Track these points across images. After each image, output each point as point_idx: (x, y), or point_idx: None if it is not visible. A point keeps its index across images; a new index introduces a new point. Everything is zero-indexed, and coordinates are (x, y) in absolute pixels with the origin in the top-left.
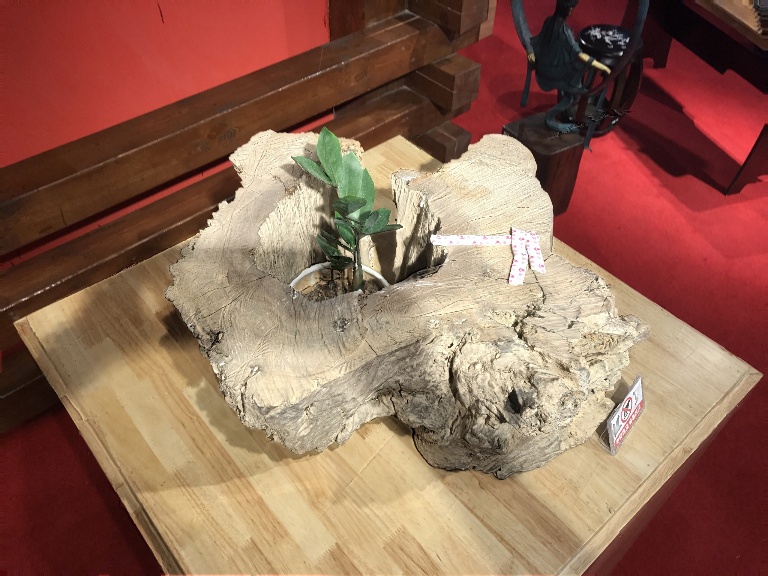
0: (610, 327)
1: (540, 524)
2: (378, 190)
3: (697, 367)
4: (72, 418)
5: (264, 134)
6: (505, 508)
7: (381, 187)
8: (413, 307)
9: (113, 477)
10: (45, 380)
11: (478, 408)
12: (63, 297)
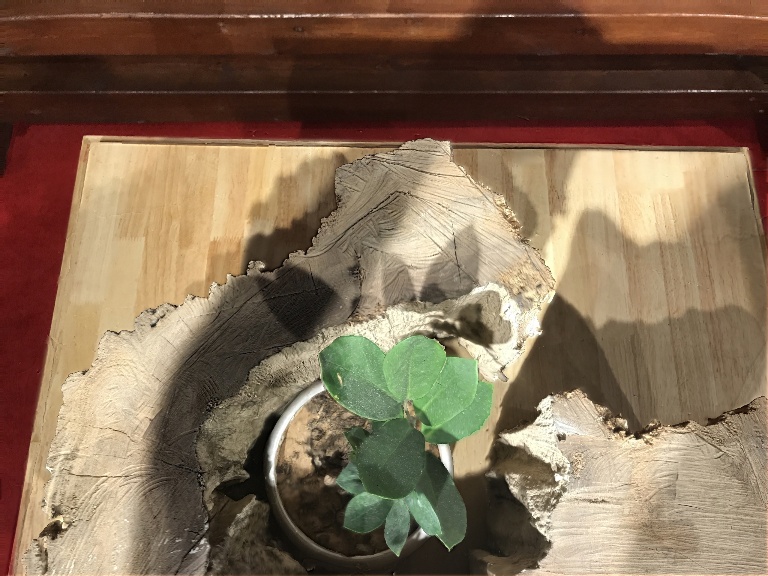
0: None
1: None
2: (624, 238)
3: None
4: None
5: (430, 146)
6: None
7: (632, 236)
8: None
9: (39, 424)
10: (63, 241)
11: None
12: (149, 135)
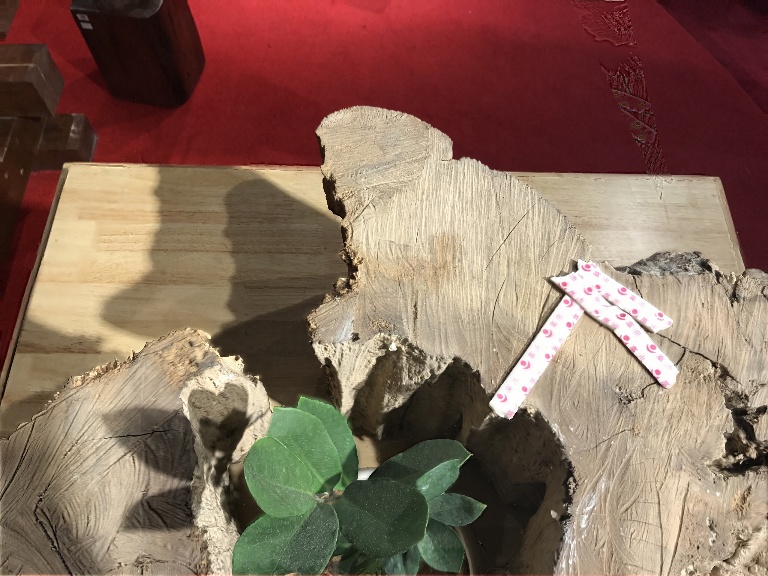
0: None
1: None
2: (141, 283)
3: (684, 223)
4: None
5: None
6: None
7: (139, 274)
8: None
9: None
10: None
11: None
12: None
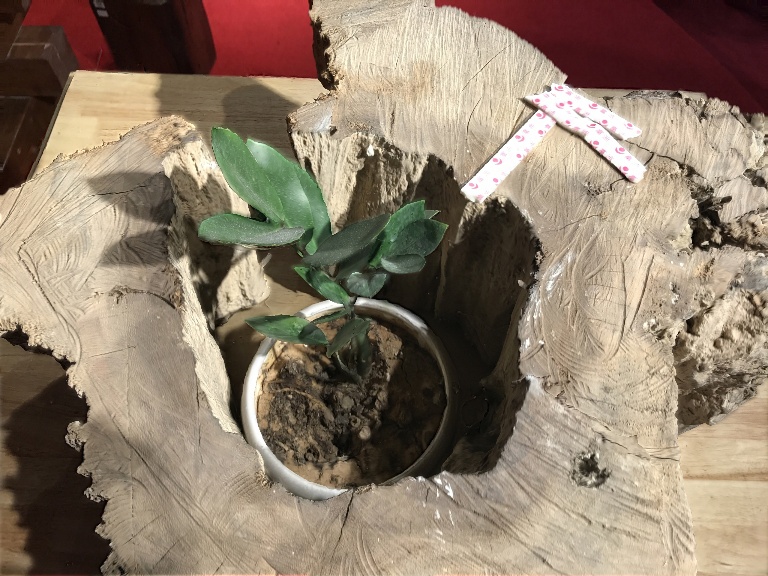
0: (759, 148)
1: (750, 421)
2: None
3: None
4: None
5: None
6: (709, 439)
7: None
8: (596, 329)
9: None
10: None
11: (742, 383)
12: None
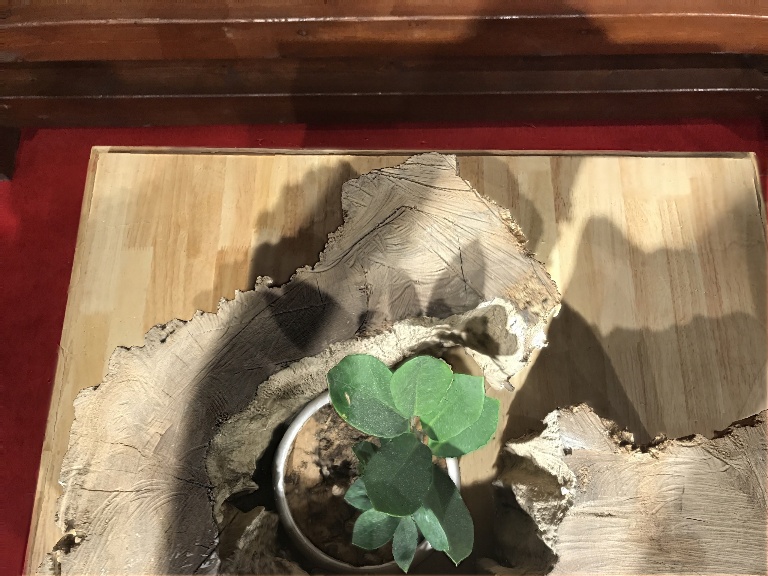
0: None
1: None
2: (630, 245)
3: None
4: (56, 331)
5: (436, 160)
6: None
7: (639, 243)
8: None
9: (50, 432)
10: (73, 251)
11: None
12: (157, 145)
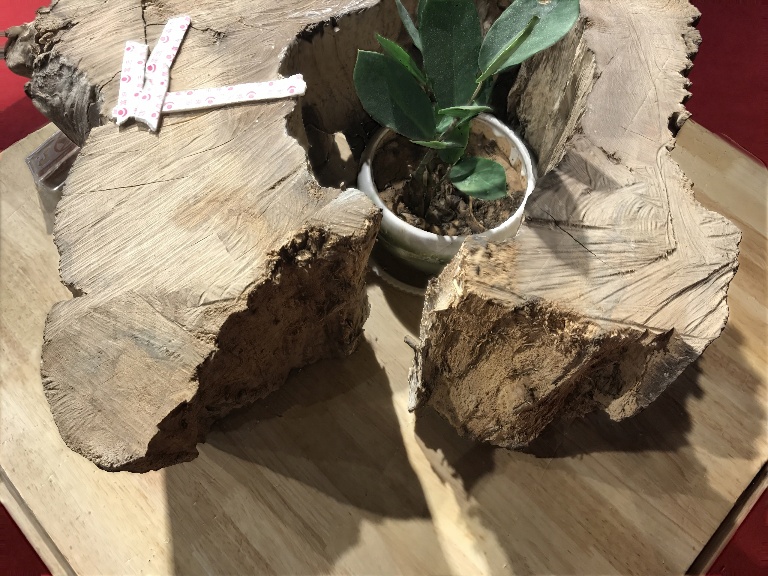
0: None
1: None
2: None
3: None
4: None
5: (707, 327)
6: None
7: None
8: None
9: None
10: None
11: None
12: None
